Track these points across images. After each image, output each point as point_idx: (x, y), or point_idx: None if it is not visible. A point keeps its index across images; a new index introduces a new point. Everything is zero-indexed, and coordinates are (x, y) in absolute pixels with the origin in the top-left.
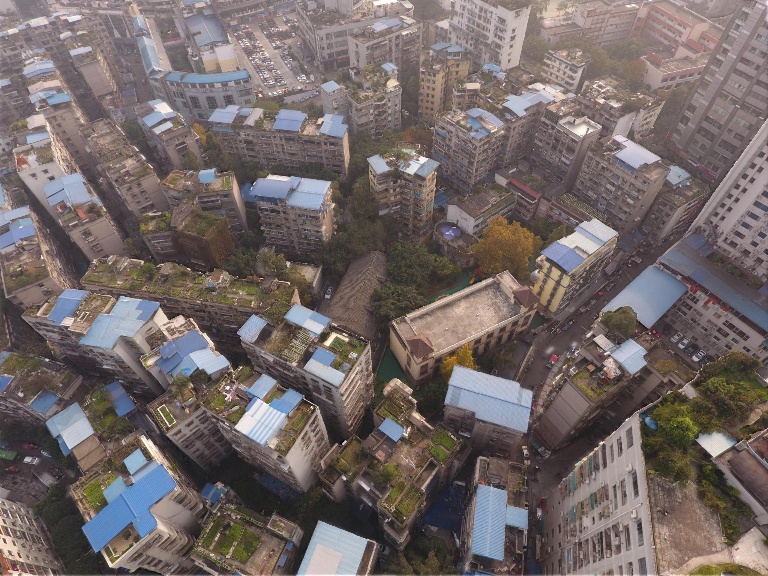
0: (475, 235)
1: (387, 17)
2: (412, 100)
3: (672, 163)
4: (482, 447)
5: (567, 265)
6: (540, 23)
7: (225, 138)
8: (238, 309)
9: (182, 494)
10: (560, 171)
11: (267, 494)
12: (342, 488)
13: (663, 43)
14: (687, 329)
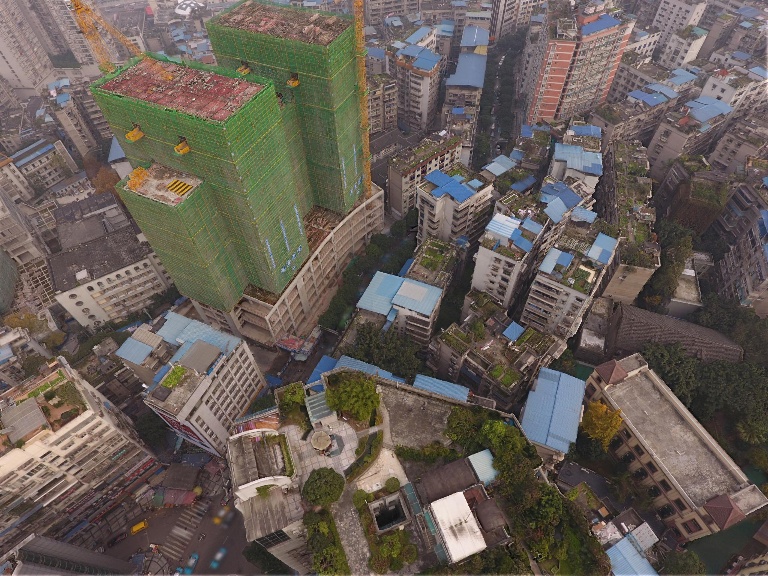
0: None
1: None
2: None
3: None
4: None
5: None
6: None
7: None
8: None
9: (458, 215)
10: None
11: None
12: None
13: None
14: None
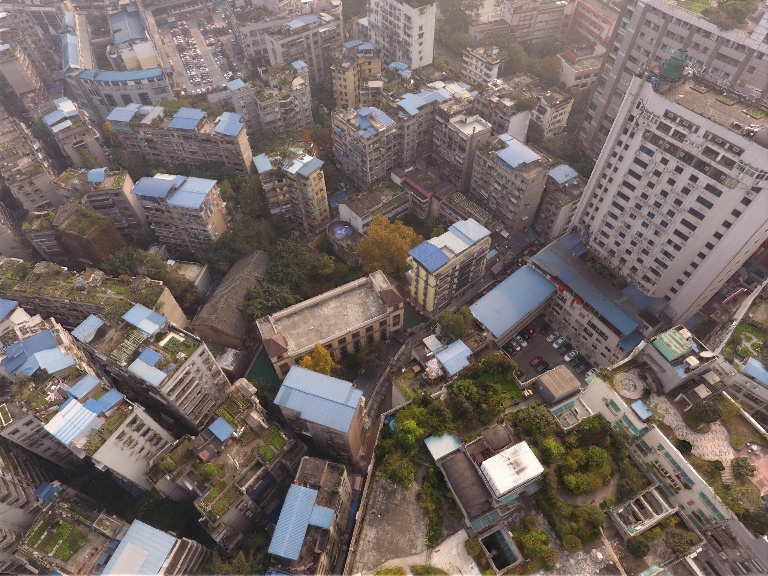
0: (366, 234)
1: (313, 14)
2: (332, 98)
3: (564, 162)
4: (326, 446)
5: (430, 265)
6: (468, 20)
7: (126, 136)
8: (105, 308)
9: (2, 493)
10: (456, 170)
11: (123, 492)
12: (175, 487)
13: (590, 40)
14: (562, 329)
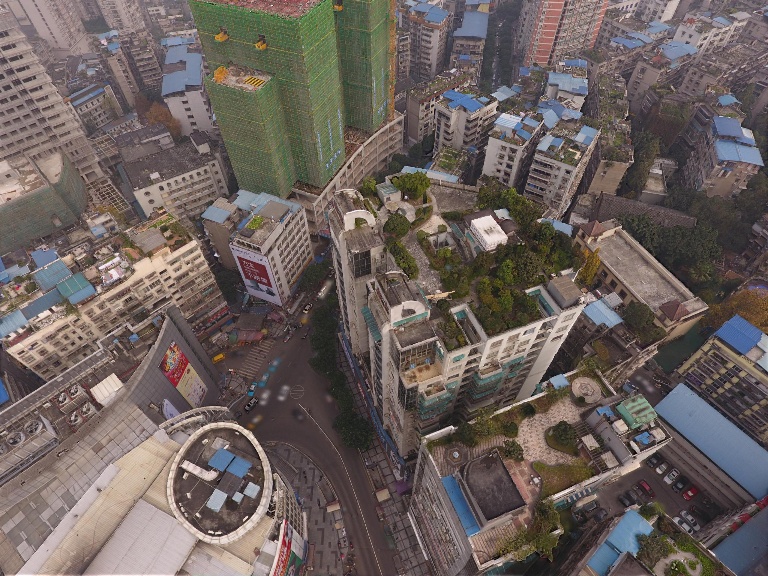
0: None
1: None
2: None
3: None
4: None
5: (726, 333)
6: None
7: None
8: (599, 139)
9: (470, 125)
10: None
11: None
12: None
13: None
14: None
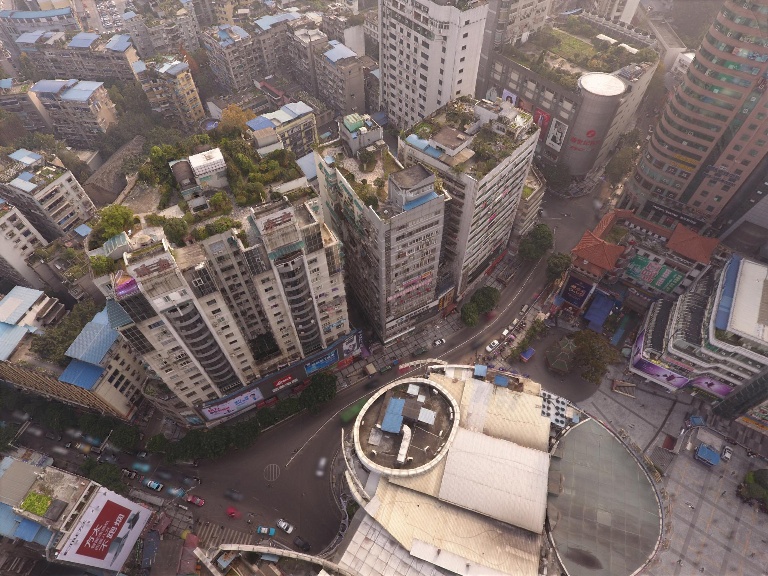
0: None
1: None
2: None
3: None
4: None
5: None
6: None
7: (34, 58)
8: None
9: None
10: (307, 76)
11: None
12: (53, 277)
13: None
14: None
